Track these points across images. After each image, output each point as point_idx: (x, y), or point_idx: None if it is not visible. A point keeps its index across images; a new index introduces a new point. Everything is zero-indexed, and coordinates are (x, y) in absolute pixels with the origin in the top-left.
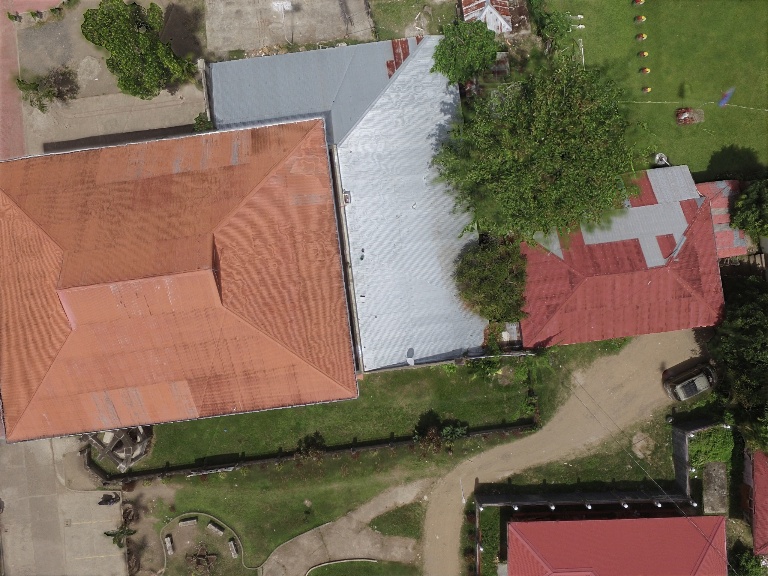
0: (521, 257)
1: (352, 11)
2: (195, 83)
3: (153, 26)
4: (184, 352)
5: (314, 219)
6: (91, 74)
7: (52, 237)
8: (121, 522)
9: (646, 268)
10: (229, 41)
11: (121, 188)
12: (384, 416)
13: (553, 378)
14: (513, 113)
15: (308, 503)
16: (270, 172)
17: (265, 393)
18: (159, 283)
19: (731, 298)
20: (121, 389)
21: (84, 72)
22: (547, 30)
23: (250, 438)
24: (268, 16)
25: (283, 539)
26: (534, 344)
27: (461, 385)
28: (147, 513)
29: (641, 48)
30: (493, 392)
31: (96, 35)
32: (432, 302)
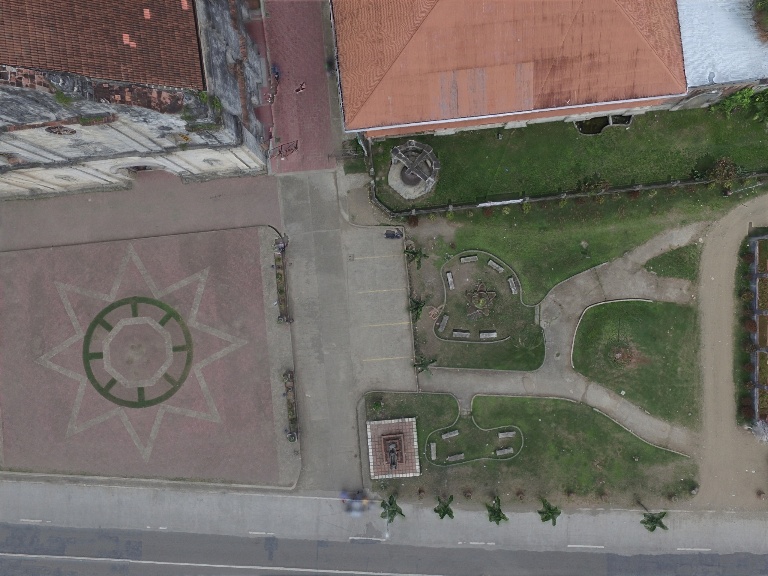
0: None
1: None
2: None
3: None
4: (540, 26)
5: None
6: None
7: None
8: (404, 257)
9: None
10: None
11: None
12: (661, 159)
13: None
14: None
15: (584, 244)
16: None
17: (602, 83)
18: None
19: None
20: (469, 70)
21: None
22: None
23: (530, 178)
24: None
25: (561, 278)
26: None
27: (738, 130)
28: (428, 250)
29: None
30: None
31: None
32: (731, 29)
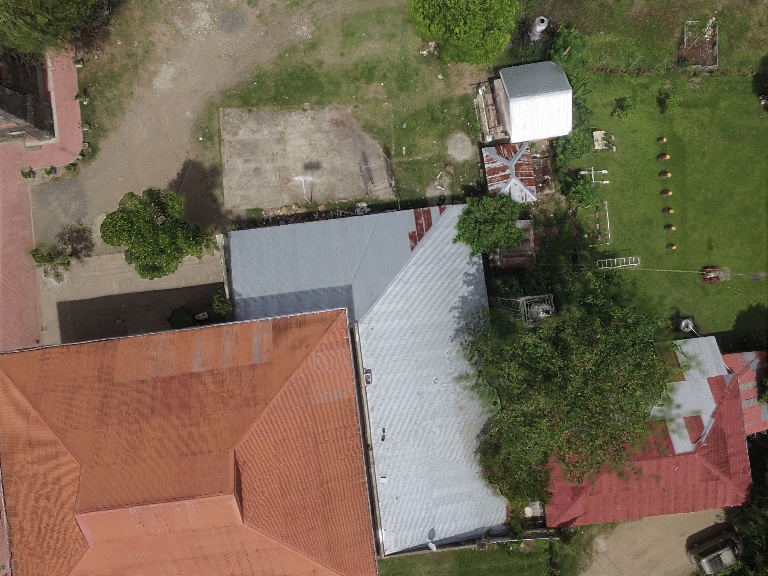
0: None
1: (372, 169)
2: (213, 255)
3: (172, 216)
4: (203, 563)
5: (336, 415)
6: None
7: (69, 447)
8: None
9: (674, 454)
10: (247, 199)
11: (139, 388)
12: None
13: (575, 545)
14: (547, 358)
15: None
16: (292, 374)
17: None
18: (179, 506)
19: (759, 475)
20: None
21: None
22: (572, 197)
23: None
24: (287, 174)
25: None
26: (558, 525)
27: (481, 553)
28: None
29: (666, 204)
30: (514, 560)
31: (115, 240)
32: (454, 481)
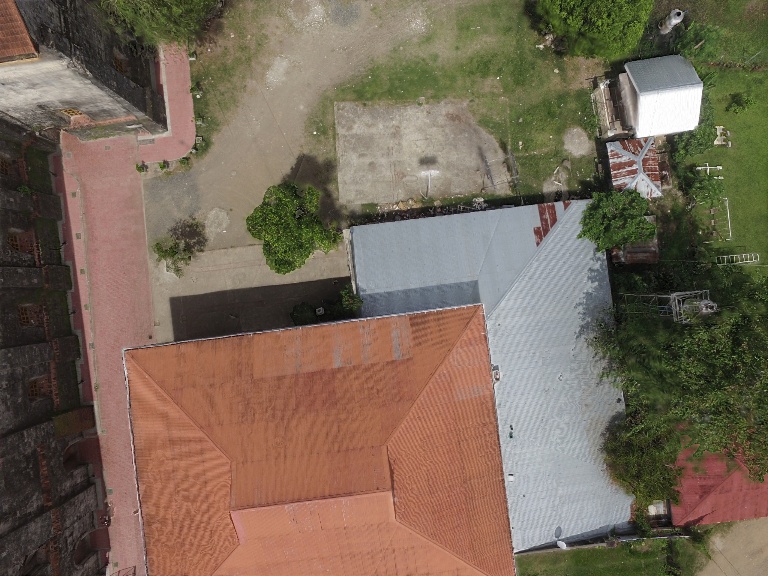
0: (677, 439)
1: None
2: None
3: (310, 210)
4: (349, 560)
5: (475, 411)
6: (219, 226)
7: (216, 443)
8: None
9: None
10: (362, 194)
11: (281, 384)
12: None
13: None
14: (726, 354)
15: None
16: (437, 370)
17: None
18: (335, 503)
19: None
20: None
21: (212, 224)
22: (695, 193)
23: None
24: (402, 169)
25: None
26: (685, 523)
27: (598, 551)
28: None
29: None
30: (631, 558)
31: (263, 234)
32: (580, 478)
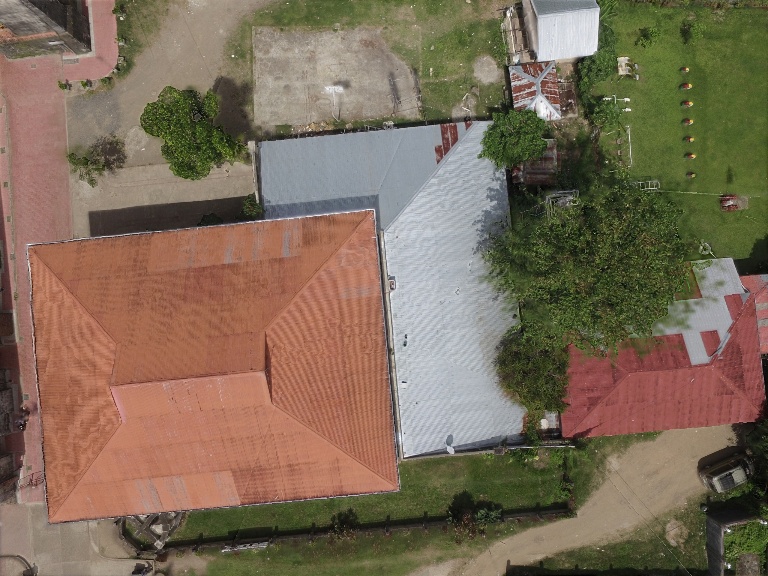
0: (565, 350)
1: (400, 89)
2: None
3: (208, 114)
4: (231, 445)
5: (362, 311)
6: (138, 144)
7: (105, 328)
8: None
9: (690, 366)
10: (276, 116)
11: (173, 277)
12: (418, 495)
13: (588, 463)
14: (575, 236)
15: None
16: (321, 267)
17: (308, 484)
18: (211, 382)
19: None
20: (166, 477)
21: (131, 142)
22: (595, 118)
23: (284, 512)
24: (316, 92)
25: None
26: (574, 435)
27: (496, 467)
28: None
29: (687, 133)
30: (528, 475)
31: (155, 128)
32: (473, 389)
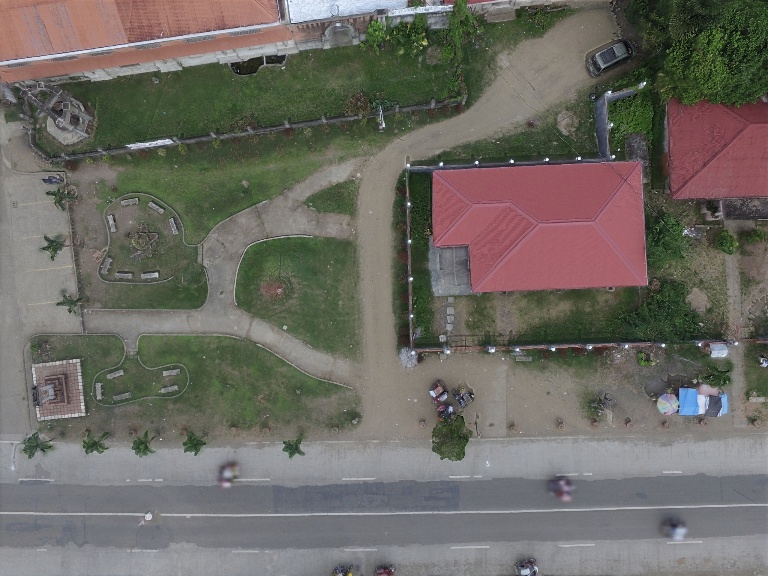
0: None
1: None
2: None
3: None
4: None
5: None
6: None
7: None
8: None
9: None
10: None
11: None
12: (317, 97)
13: (480, 60)
14: None
15: (246, 183)
16: None
17: (190, 14)
18: None
19: None
20: (50, 4)
21: None
22: None
23: (188, 120)
24: None
25: (222, 217)
26: None
27: (391, 65)
28: (90, 194)
29: None
30: (422, 72)
31: None
32: None
